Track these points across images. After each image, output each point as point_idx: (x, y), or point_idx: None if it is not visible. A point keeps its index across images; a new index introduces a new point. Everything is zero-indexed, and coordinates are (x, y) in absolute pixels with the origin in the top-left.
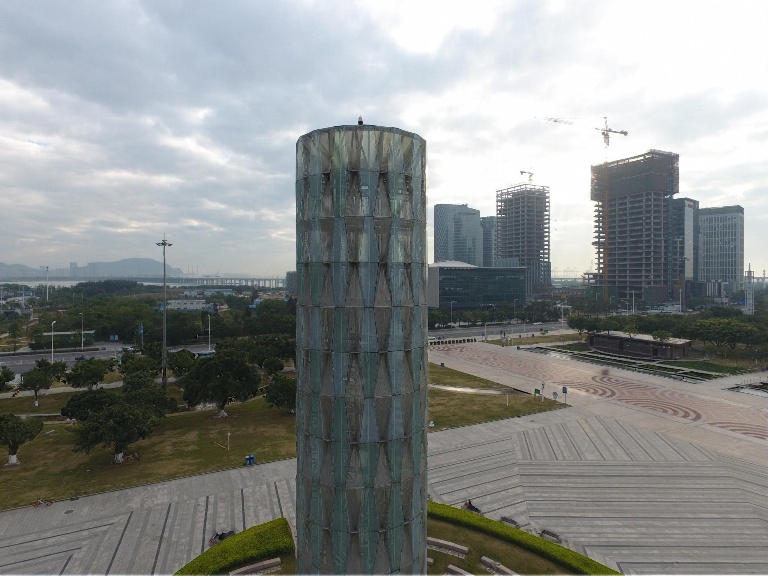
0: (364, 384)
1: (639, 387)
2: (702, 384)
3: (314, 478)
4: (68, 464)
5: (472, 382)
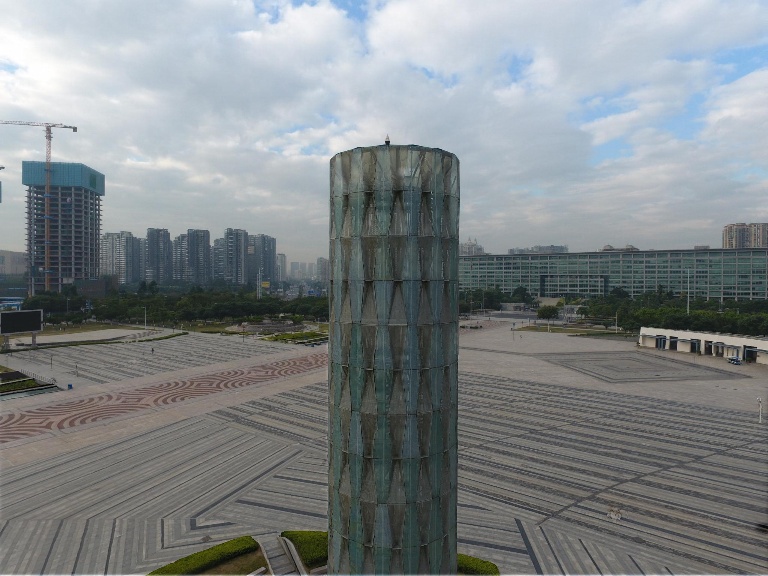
0: None
1: None
2: None
3: None
4: None
5: None
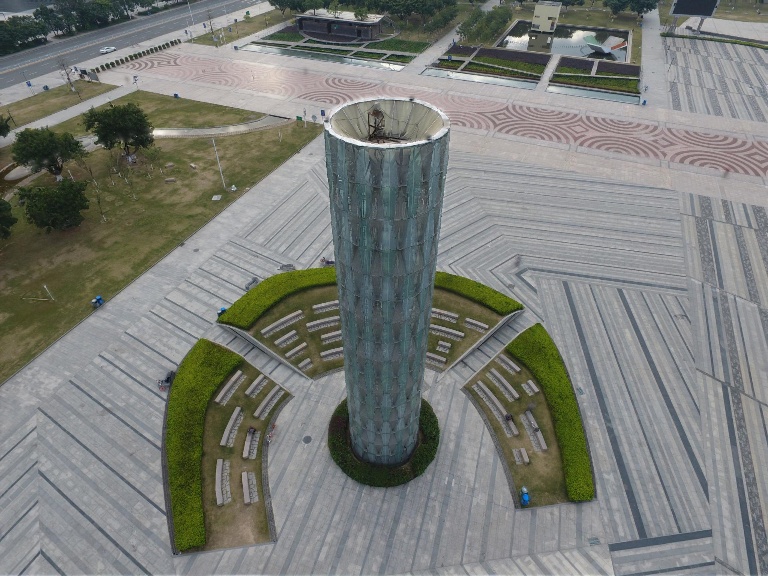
0: None
1: (365, 86)
2: (405, 71)
3: (386, 361)
4: None
5: (227, 116)
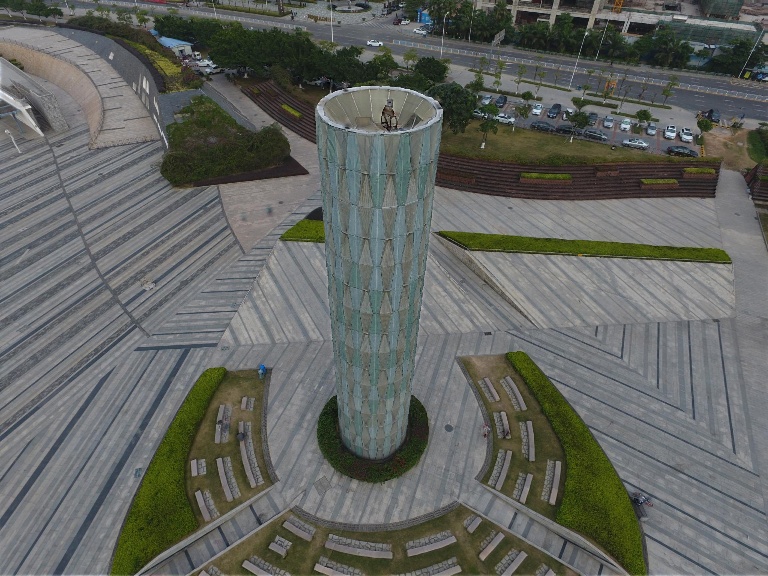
0: None
1: None
2: None
3: None
4: None
5: None
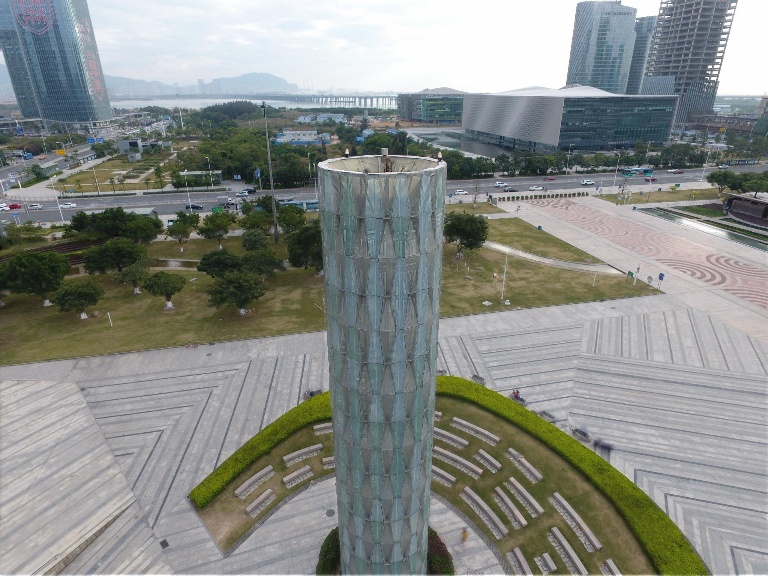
0: (372, 384)
1: (760, 274)
2: None
3: (340, 433)
4: (207, 312)
5: (565, 253)
